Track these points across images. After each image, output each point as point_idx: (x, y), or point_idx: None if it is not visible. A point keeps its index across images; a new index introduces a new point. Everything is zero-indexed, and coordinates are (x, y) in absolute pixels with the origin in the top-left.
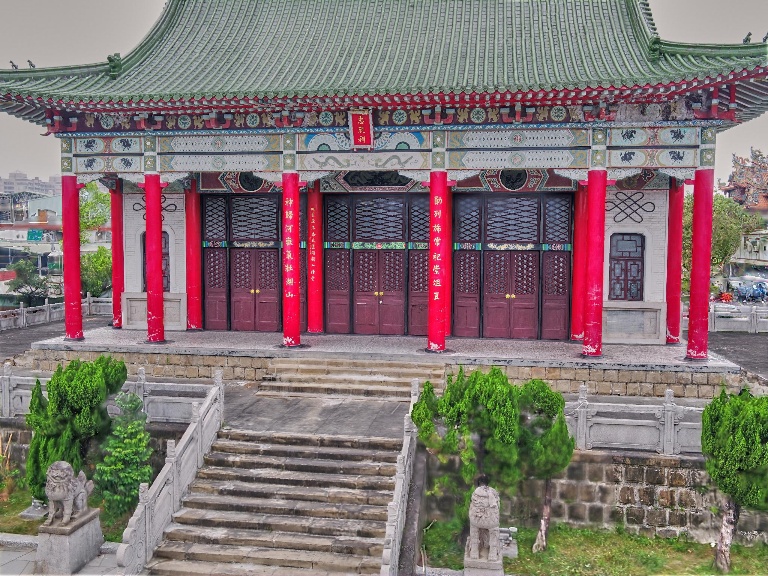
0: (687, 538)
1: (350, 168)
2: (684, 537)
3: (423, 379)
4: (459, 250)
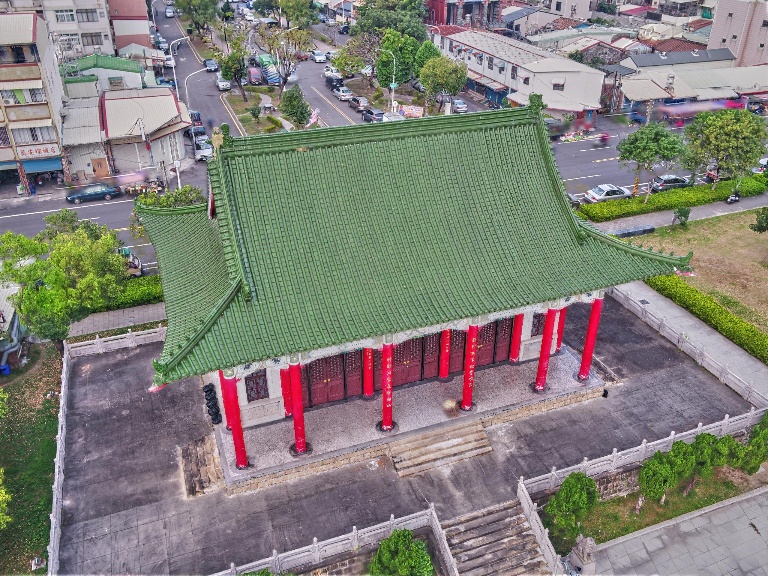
0: (617, 497)
1: (425, 333)
2: (616, 497)
3: (475, 435)
4: (454, 330)
